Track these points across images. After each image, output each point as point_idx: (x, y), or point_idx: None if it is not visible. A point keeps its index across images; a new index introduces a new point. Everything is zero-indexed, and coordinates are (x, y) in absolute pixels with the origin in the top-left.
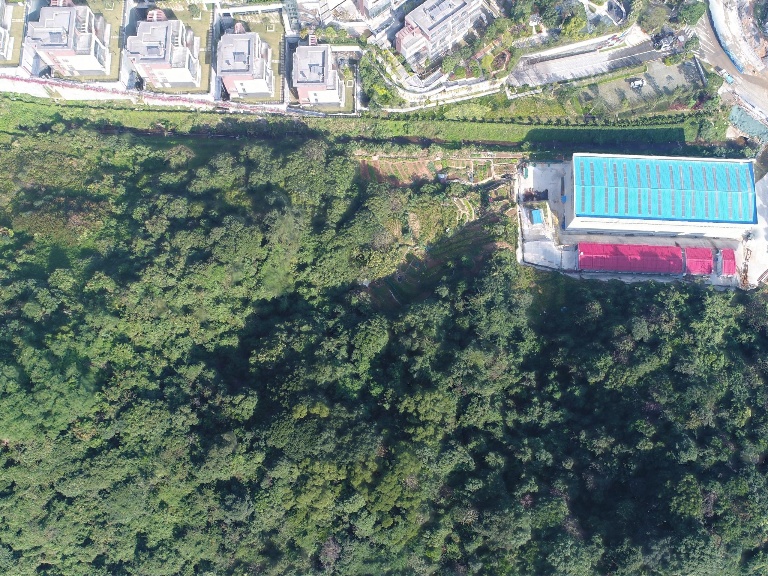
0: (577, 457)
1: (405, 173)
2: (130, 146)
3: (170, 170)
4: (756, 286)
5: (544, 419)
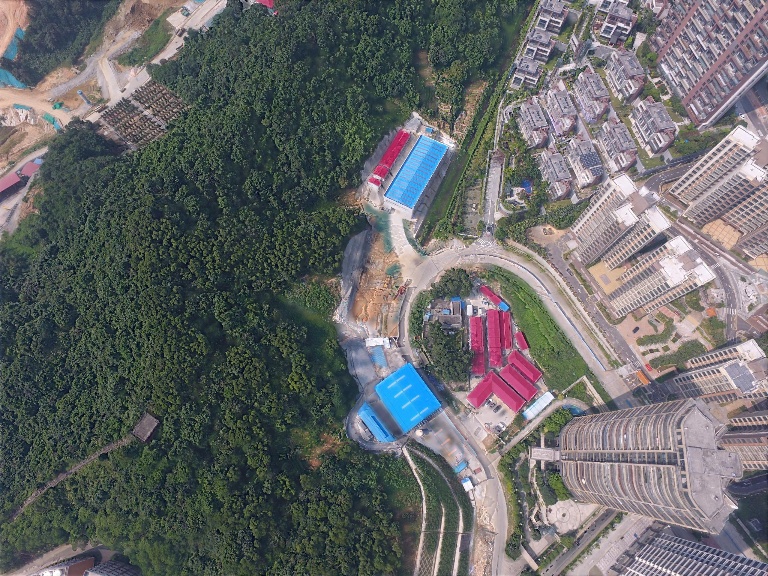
0: (332, 65)
1: (471, 99)
2: (517, 3)
3: (500, 4)
4: (360, 201)
5: (350, 69)
